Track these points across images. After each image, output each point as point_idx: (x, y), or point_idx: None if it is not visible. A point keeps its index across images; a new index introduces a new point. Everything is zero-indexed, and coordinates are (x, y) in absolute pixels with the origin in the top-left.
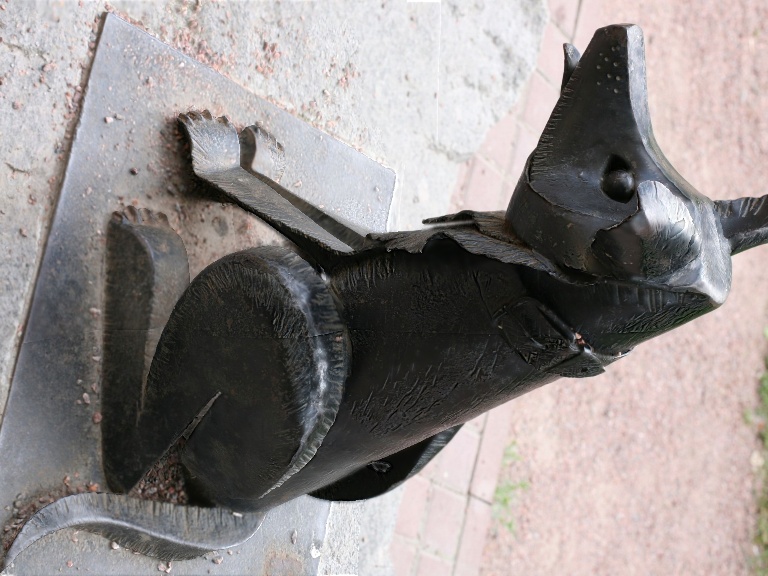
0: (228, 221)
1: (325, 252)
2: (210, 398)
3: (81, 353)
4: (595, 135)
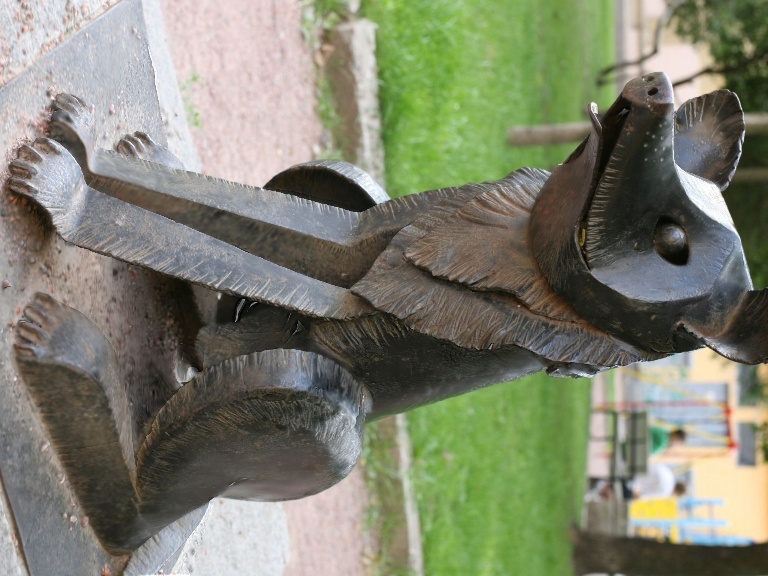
0: None
1: (310, 319)
2: None
3: (53, 492)
4: (645, 205)
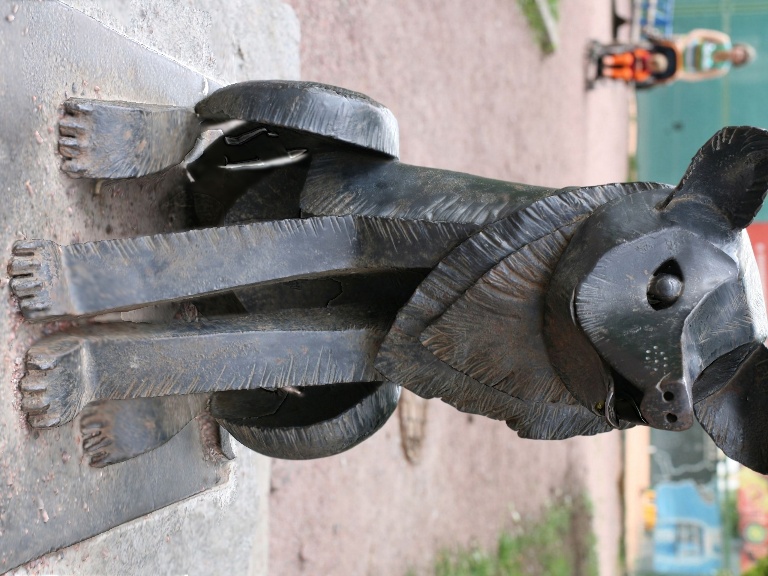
0: None
1: None
2: None
3: None
4: None
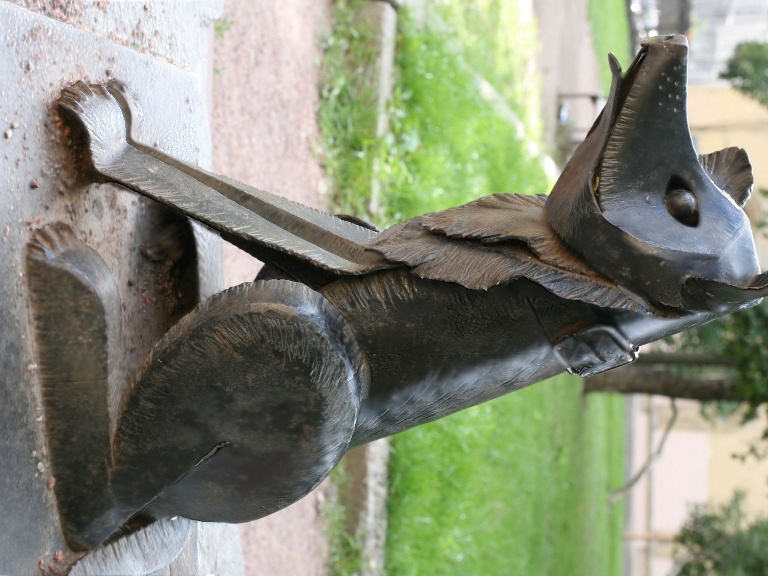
0: (102, 199)
1: (321, 271)
2: (213, 448)
3: (28, 421)
4: (657, 157)
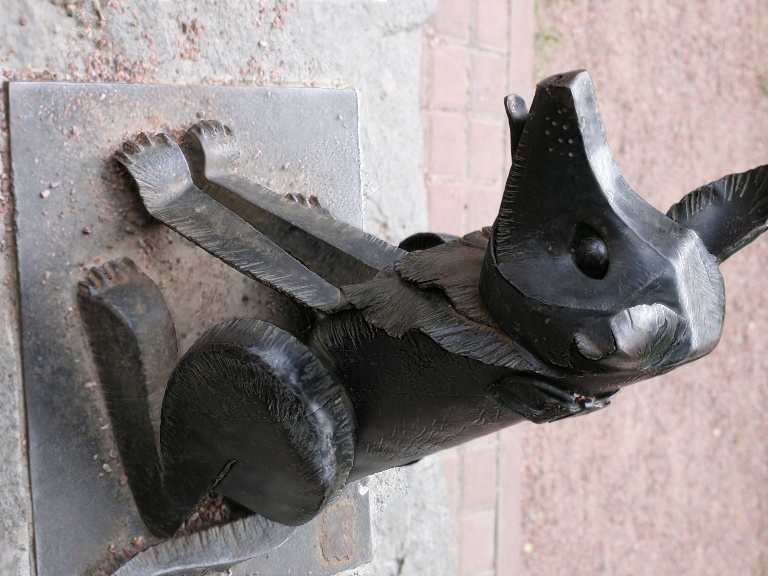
0: None
1: (303, 308)
2: (226, 464)
3: (89, 430)
4: (557, 205)
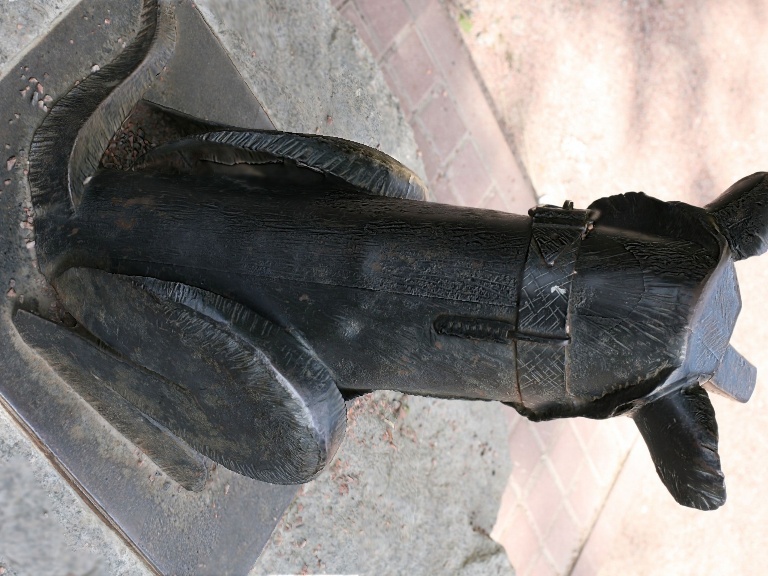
0: None
1: None
2: None
3: None
4: None
